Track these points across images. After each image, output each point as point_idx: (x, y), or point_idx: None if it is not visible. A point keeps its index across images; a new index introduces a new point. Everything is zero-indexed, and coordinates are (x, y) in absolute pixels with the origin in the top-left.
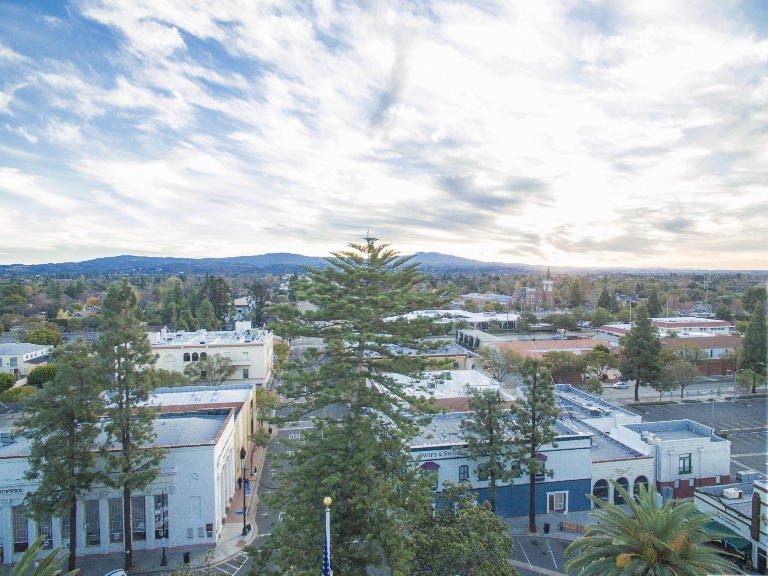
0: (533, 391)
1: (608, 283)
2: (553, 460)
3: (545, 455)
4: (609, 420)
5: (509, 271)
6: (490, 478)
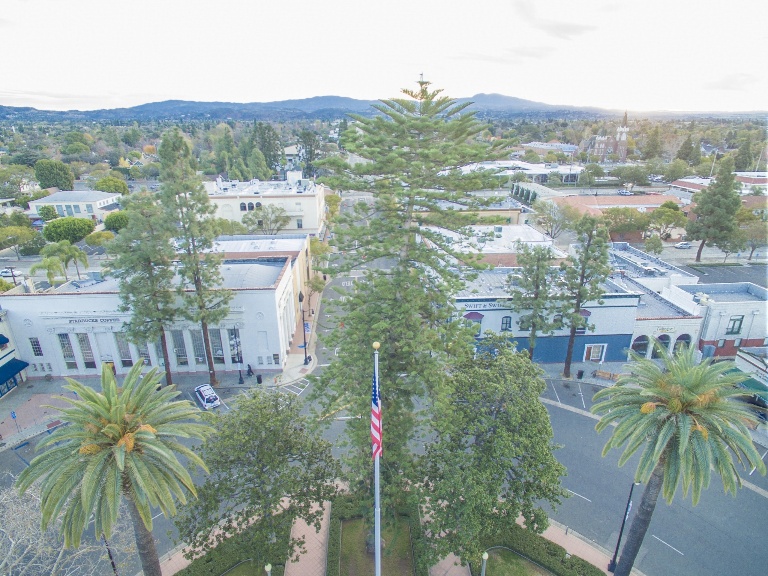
0: (586, 249)
1: (694, 130)
2: (596, 316)
3: (589, 311)
4: (663, 280)
5: (580, 116)
6: (531, 329)
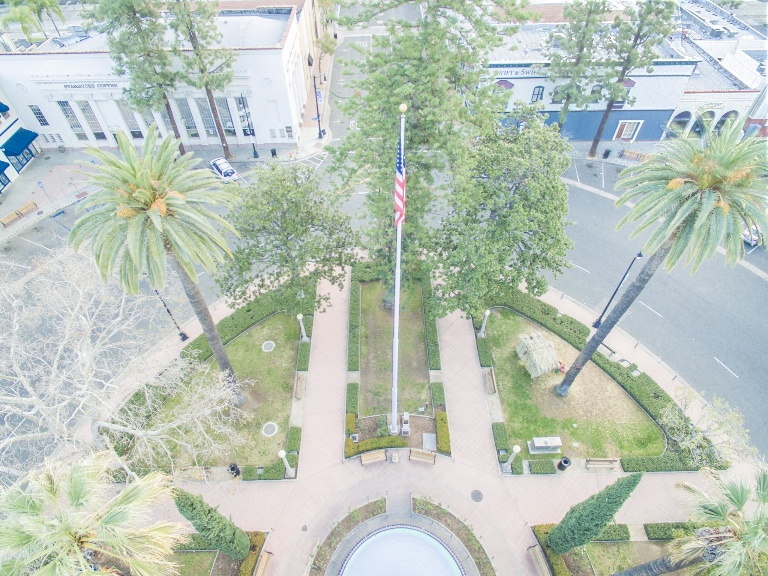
0: None
1: None
2: (641, 87)
3: (634, 80)
4: (729, 43)
5: None
6: (564, 102)
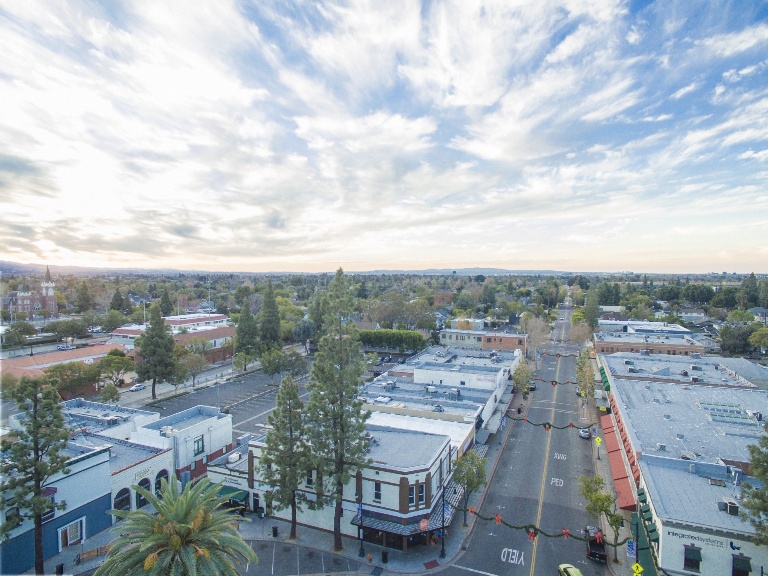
0: (33, 416)
1: (120, 284)
2: (64, 489)
3: (54, 487)
4: (128, 425)
5: None
6: None
